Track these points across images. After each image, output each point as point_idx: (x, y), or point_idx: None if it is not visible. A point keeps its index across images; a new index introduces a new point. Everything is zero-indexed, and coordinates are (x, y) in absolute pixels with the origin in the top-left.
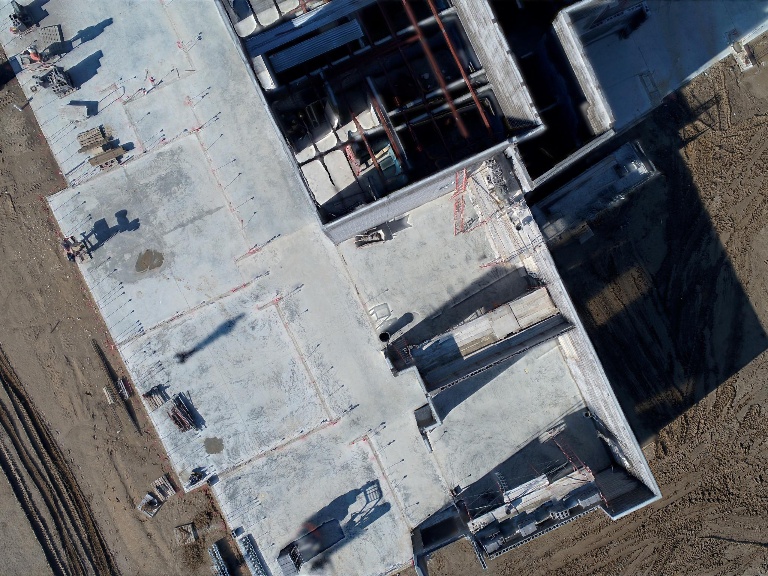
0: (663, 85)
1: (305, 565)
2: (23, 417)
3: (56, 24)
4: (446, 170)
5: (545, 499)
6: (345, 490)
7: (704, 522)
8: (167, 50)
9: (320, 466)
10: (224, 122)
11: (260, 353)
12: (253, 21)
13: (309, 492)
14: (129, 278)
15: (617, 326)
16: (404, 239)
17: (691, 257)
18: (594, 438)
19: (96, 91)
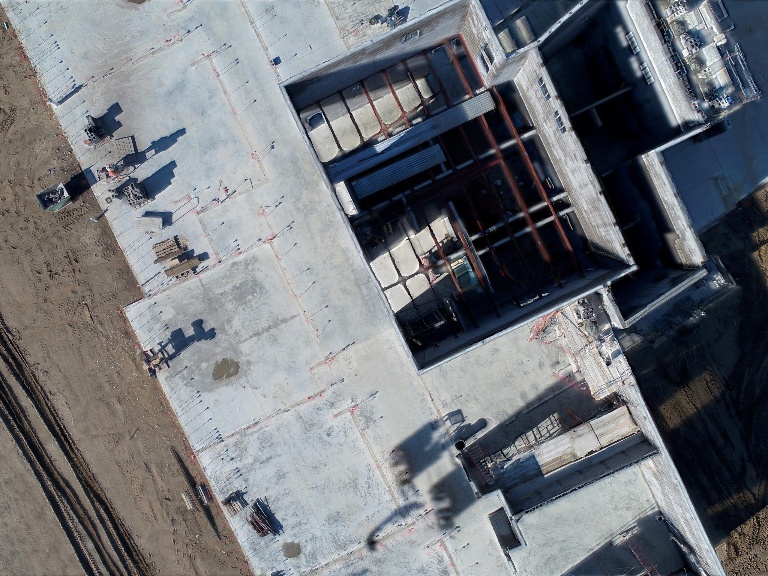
0: (738, 188)
1: None
2: (104, 521)
3: (130, 135)
4: (541, 315)
5: None
6: None
7: None
8: (240, 160)
9: (396, 569)
10: (298, 231)
11: (336, 459)
12: (325, 129)
13: None
14: (206, 387)
15: (689, 429)
16: None
17: (764, 360)
18: (667, 540)
19: (170, 202)
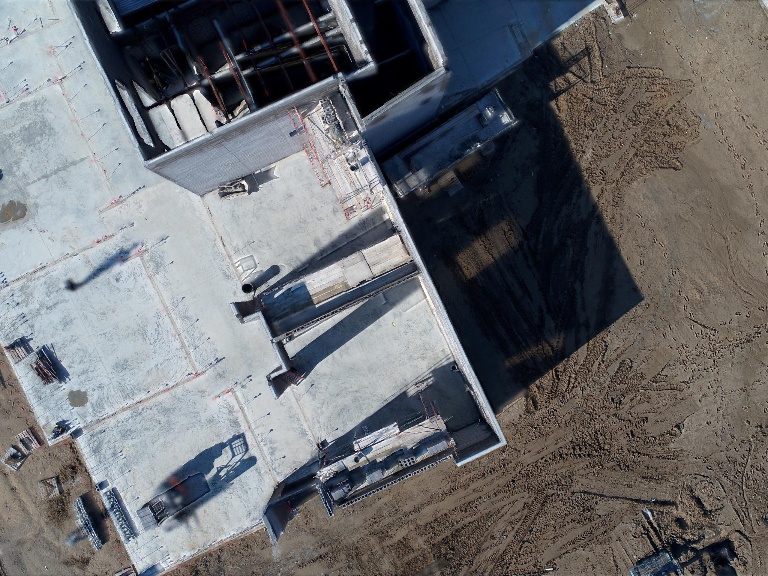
0: (533, 36)
1: (170, 519)
2: None
3: None
4: (270, 106)
5: (396, 447)
6: (211, 444)
7: (575, 477)
8: None
9: (185, 419)
10: (88, 72)
11: (125, 305)
12: None
13: (174, 445)
14: None
15: (487, 280)
16: (270, 191)
17: (562, 210)
18: (462, 392)
19: None
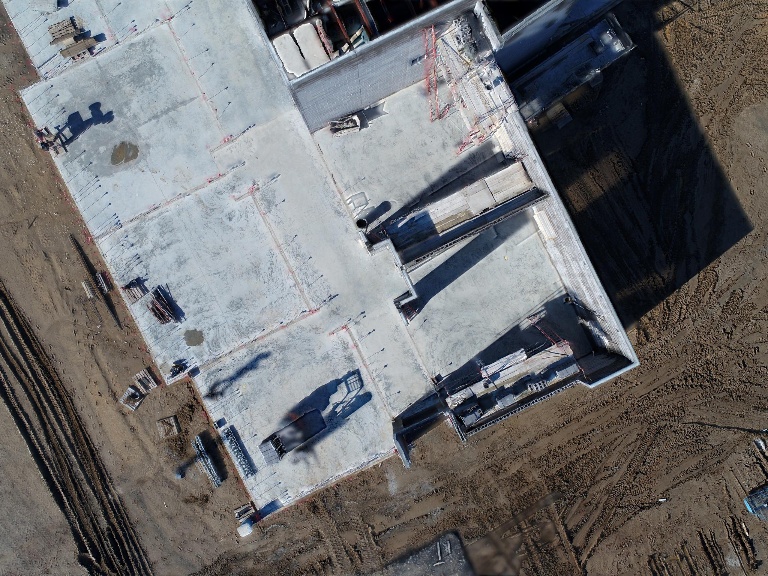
0: None
1: (288, 455)
2: (3, 314)
3: None
4: (413, 23)
5: (523, 373)
6: (326, 380)
7: (687, 408)
8: None
9: (300, 357)
10: (196, 11)
11: (238, 244)
12: None
13: (290, 383)
14: (105, 171)
15: (597, 212)
16: (380, 127)
17: (671, 141)
18: (575, 324)
19: None
